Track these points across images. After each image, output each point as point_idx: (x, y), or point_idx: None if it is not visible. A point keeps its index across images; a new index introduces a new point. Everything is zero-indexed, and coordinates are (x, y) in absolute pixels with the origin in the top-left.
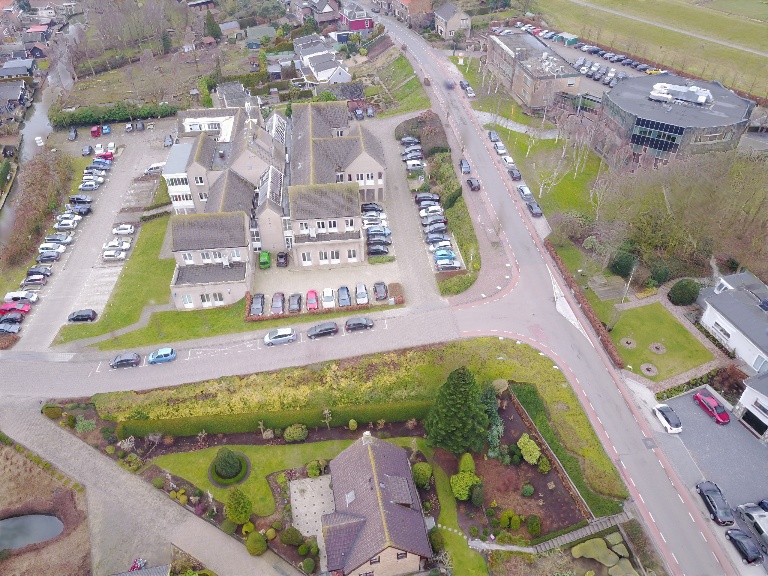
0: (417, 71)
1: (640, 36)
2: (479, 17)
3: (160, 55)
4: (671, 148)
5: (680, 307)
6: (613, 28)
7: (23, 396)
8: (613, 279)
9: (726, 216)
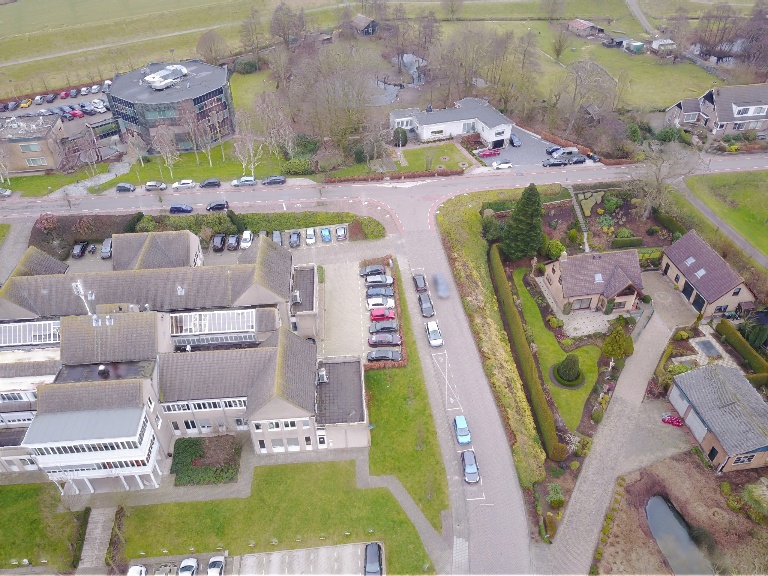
0: None
1: None
2: None
3: None
4: (223, 107)
5: (407, 145)
6: None
7: None
8: (374, 163)
9: (343, 99)
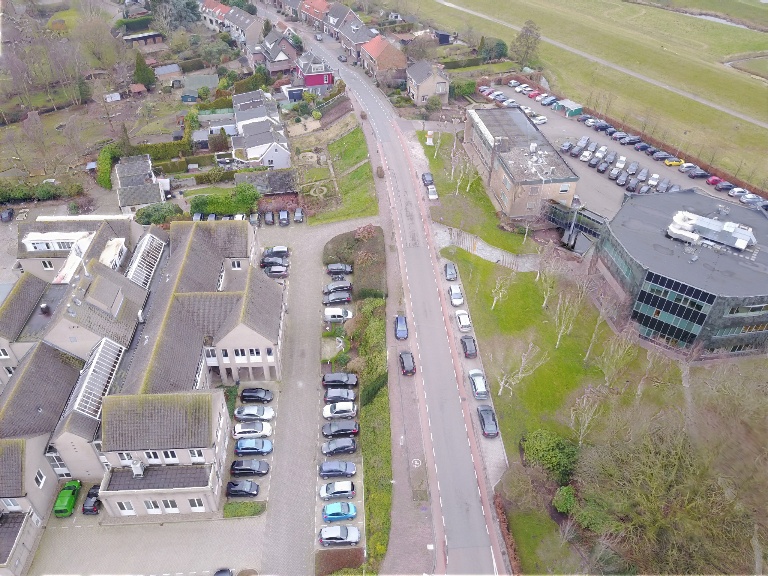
0: (372, 153)
1: (659, 107)
2: (467, 71)
3: (75, 106)
4: (695, 318)
5: None
6: (627, 93)
7: None
8: None
9: None
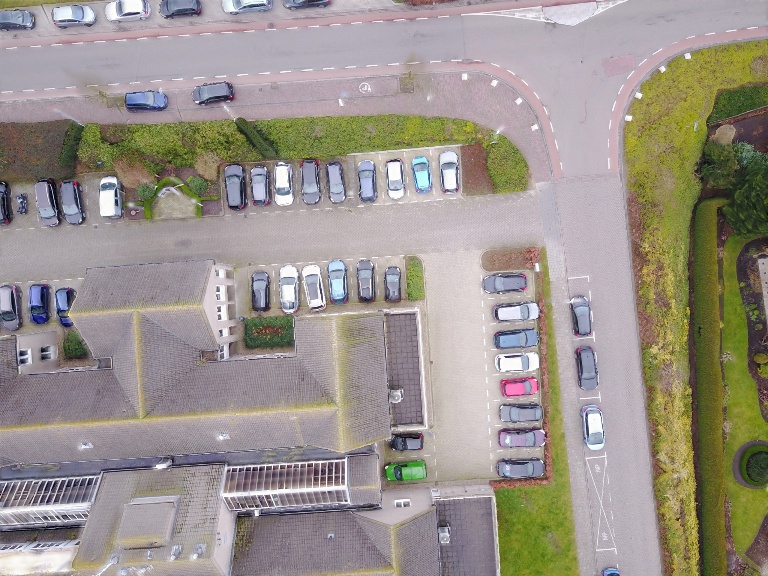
0: None
1: None
2: None
3: None
4: None
5: None
6: None
7: None
8: None
9: None
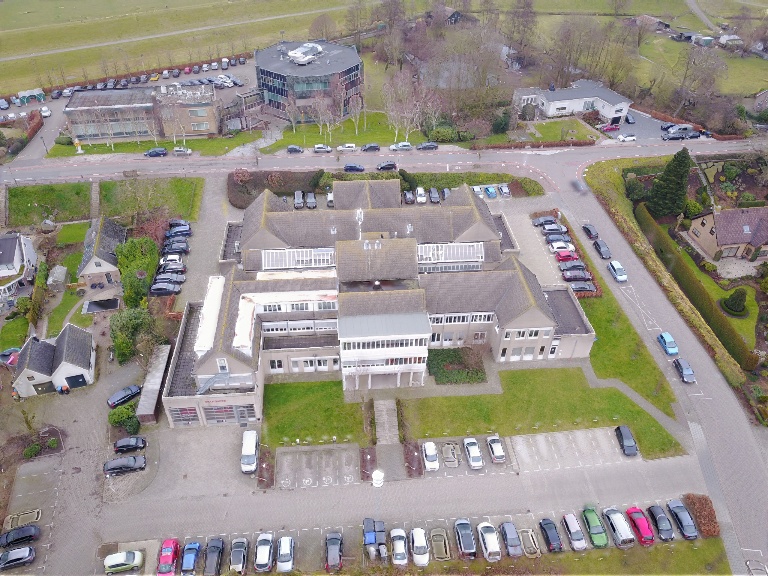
0: (81, 180)
1: None
2: None
3: None
4: (358, 82)
5: (535, 119)
6: (18, 74)
7: (761, 450)
8: None
9: None
